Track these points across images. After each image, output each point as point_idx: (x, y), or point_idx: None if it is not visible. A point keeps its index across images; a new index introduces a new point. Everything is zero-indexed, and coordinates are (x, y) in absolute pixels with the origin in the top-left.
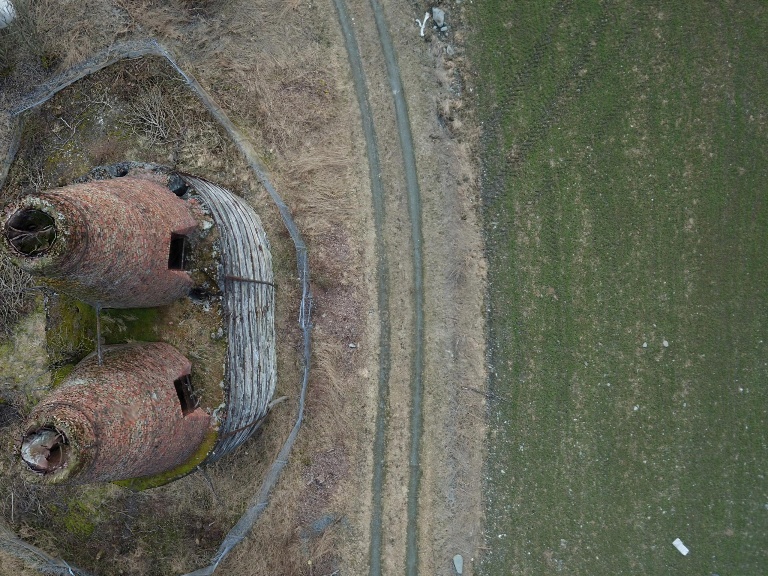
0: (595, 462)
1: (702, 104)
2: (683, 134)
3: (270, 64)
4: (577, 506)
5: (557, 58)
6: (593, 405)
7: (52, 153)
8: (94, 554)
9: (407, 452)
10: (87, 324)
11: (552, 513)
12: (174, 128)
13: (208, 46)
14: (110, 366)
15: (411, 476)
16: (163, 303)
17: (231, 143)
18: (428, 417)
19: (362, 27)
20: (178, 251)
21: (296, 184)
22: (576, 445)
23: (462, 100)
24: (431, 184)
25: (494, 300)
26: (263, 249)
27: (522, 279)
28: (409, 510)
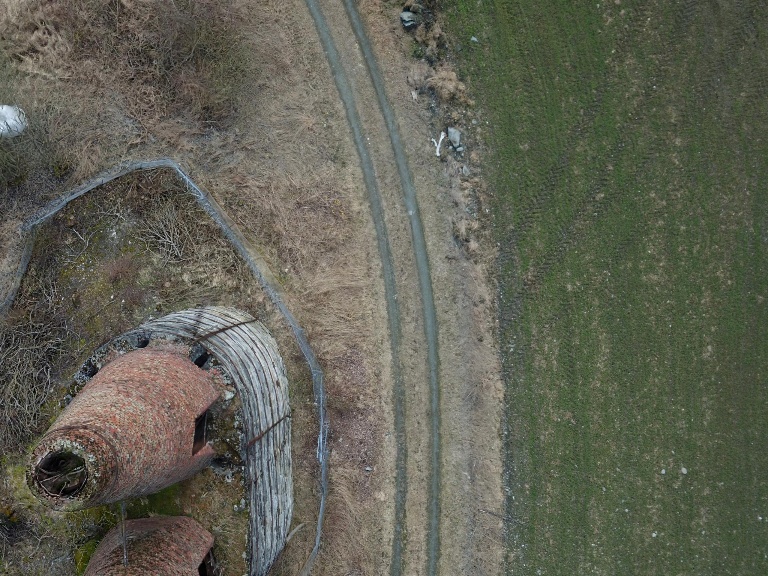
0: None
1: (720, 231)
2: (701, 261)
3: (285, 182)
4: None
5: (574, 181)
6: (611, 531)
7: (65, 266)
8: None
9: (424, 575)
10: None
11: None
12: (188, 246)
13: (222, 160)
14: (136, 566)
15: None
16: (186, 478)
17: (246, 262)
18: (445, 540)
19: (377, 147)
20: (201, 430)
21: (312, 306)
22: (594, 570)
23: (478, 221)
24: (447, 305)
25: (511, 423)
26: (280, 381)
27: (539, 402)
28: None
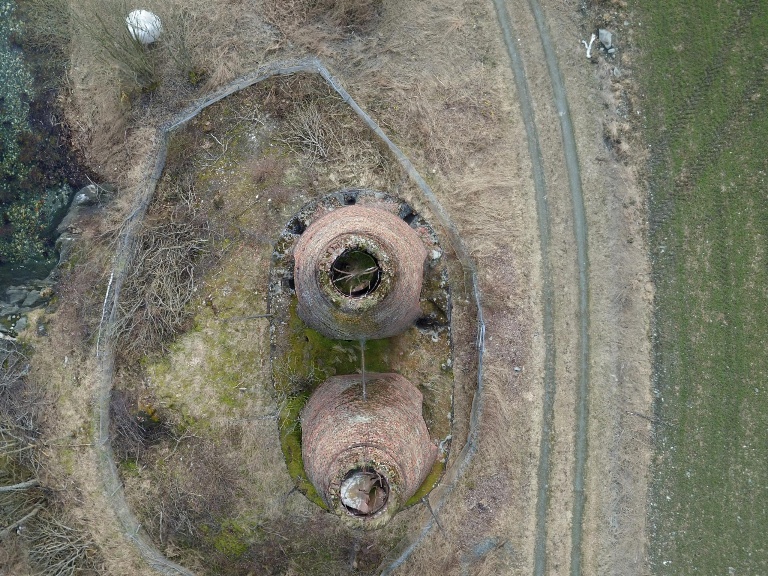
0: (765, 489)
1: None
2: None
3: (432, 84)
4: (746, 534)
5: (729, 82)
6: (763, 432)
7: (203, 170)
8: (243, 575)
9: (572, 477)
10: (317, 354)
11: (720, 540)
12: (334, 147)
13: (364, 64)
14: (375, 402)
15: (575, 501)
16: (397, 334)
17: (393, 163)
18: (593, 442)
19: (528, 48)
20: None
21: (462, 205)
22: (745, 472)
23: (629, 122)
24: (597, 207)
25: (661, 324)
26: None
27: (691, 304)
28: (573, 535)
